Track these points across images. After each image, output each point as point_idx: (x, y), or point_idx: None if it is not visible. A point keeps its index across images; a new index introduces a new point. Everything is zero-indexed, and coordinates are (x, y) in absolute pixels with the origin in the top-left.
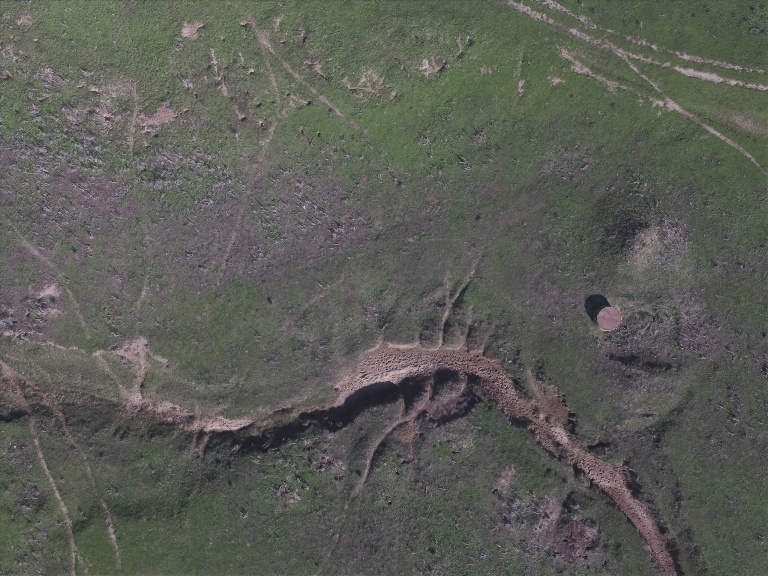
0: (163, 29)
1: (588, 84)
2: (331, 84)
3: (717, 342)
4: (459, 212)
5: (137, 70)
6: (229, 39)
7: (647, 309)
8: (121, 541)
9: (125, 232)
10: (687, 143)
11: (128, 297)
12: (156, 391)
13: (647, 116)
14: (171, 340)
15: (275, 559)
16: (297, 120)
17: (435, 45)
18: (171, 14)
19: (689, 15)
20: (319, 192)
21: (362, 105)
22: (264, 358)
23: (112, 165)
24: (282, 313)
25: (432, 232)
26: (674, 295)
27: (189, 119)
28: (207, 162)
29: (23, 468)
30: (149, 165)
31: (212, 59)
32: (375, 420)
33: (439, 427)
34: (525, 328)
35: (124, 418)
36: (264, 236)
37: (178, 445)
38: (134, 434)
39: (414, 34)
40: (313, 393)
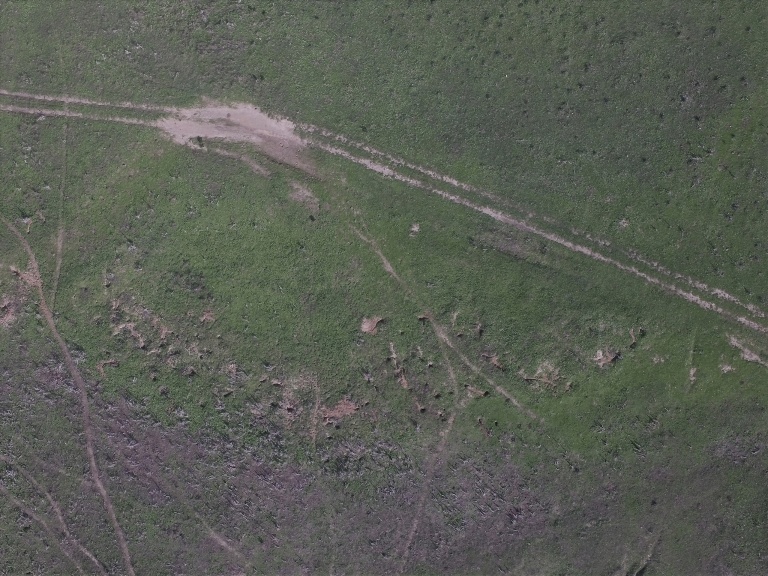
0: (343, 325)
1: (758, 371)
2: (508, 376)
3: None
4: (635, 497)
5: (318, 363)
6: (408, 333)
7: None
8: None
9: (310, 522)
10: None
11: None
12: None
13: None
14: None
15: None
16: (475, 410)
17: (609, 337)
18: (351, 310)
19: None
20: (497, 479)
21: (539, 396)
22: None
23: (296, 457)
24: None
25: (609, 517)
26: None
27: (370, 411)
28: (388, 452)
29: None
30: (332, 456)
31: (392, 353)
32: None
33: None
34: None
35: None
36: (445, 523)
37: None
38: None
39: (588, 326)
40: None
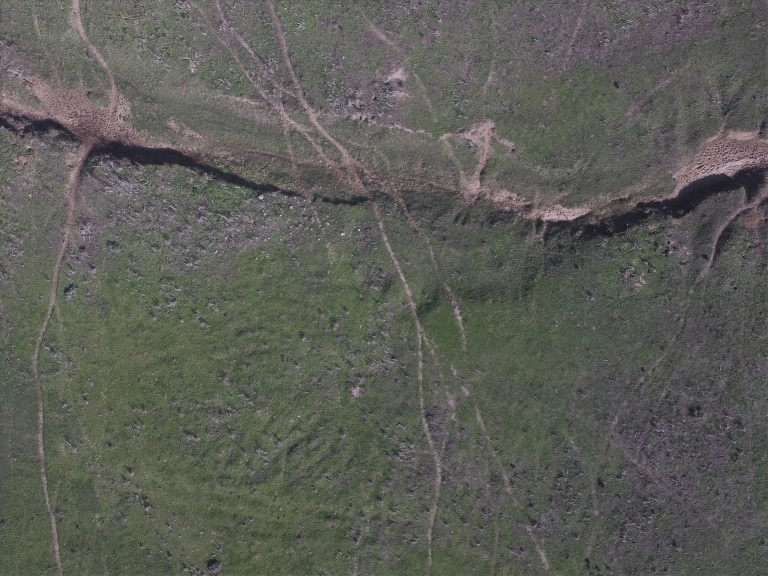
0: None
1: None
2: None
3: None
4: None
5: None
6: None
7: None
8: (467, 322)
9: (472, 17)
10: None
11: (475, 81)
12: (496, 178)
13: None
14: (518, 124)
15: (620, 342)
16: None
17: None
18: None
19: None
20: None
21: None
22: (609, 143)
23: None
24: (628, 98)
25: None
26: None
27: None
28: None
29: (368, 251)
30: None
31: None
32: (718, 206)
33: None
34: None
35: (462, 206)
36: (609, 22)
37: (519, 231)
38: (474, 220)
39: None
40: (653, 182)
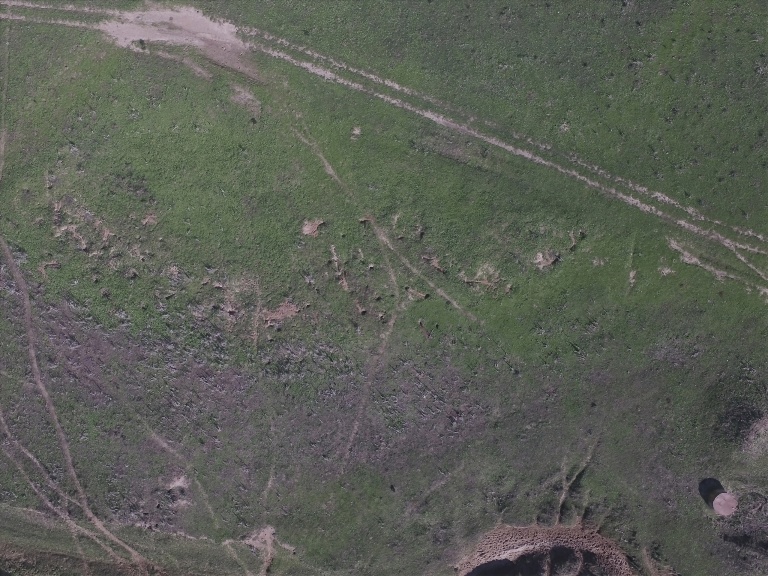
0: (285, 227)
1: (697, 274)
2: (449, 278)
3: None
4: (575, 399)
5: (259, 266)
6: (349, 236)
7: (759, 491)
8: None
9: (251, 424)
10: None
11: (255, 487)
12: (282, 575)
13: (755, 304)
14: (298, 529)
15: None
16: (416, 313)
17: (549, 239)
18: (292, 212)
19: None
20: (438, 382)
21: (479, 298)
22: (388, 544)
23: (237, 359)
24: (405, 500)
25: (549, 419)
26: None
27: (311, 314)
28: (329, 355)
29: None
30: (273, 358)
31: (333, 255)
32: None
33: None
34: (641, 511)
35: None
36: (385, 425)
37: None
38: None
39: (528, 229)
40: (434, 574)
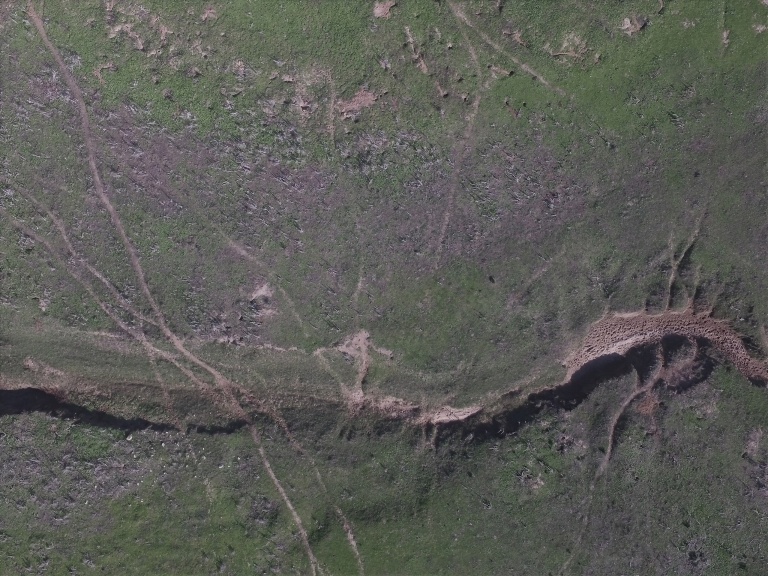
0: (355, 11)
1: None
2: (533, 52)
3: None
4: (676, 171)
5: (330, 56)
6: (423, 15)
7: None
8: (362, 547)
9: (335, 223)
10: None
11: (344, 290)
12: (379, 386)
13: None
14: (394, 330)
15: (524, 549)
16: (501, 92)
17: (635, 3)
18: None
19: None
20: (530, 163)
21: (567, 70)
22: (491, 340)
23: (314, 155)
24: (505, 291)
25: (651, 193)
26: None
27: (390, 101)
28: (412, 143)
29: (250, 480)
30: (352, 152)
31: (408, 37)
32: (611, 393)
33: (680, 394)
34: (757, 283)
35: (347, 418)
36: (478, 214)
37: (408, 440)
38: (360, 433)
39: None
40: (542, 372)
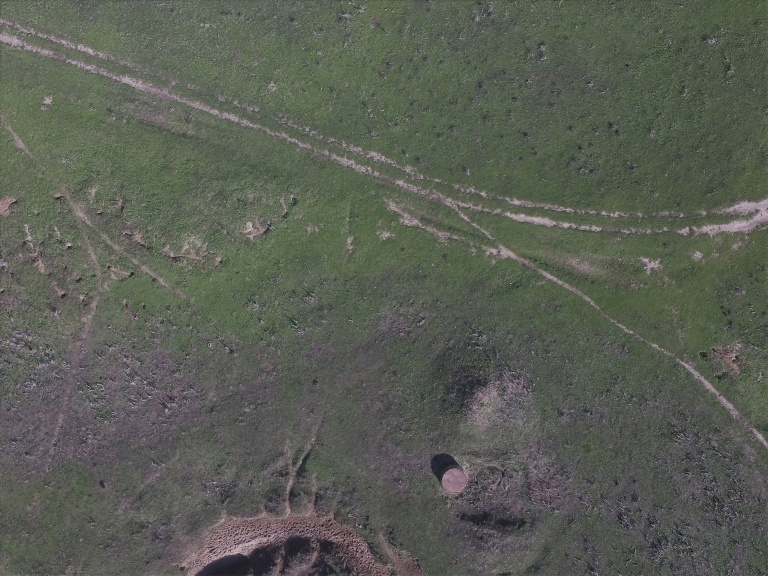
0: None
1: (419, 236)
2: (152, 254)
3: (570, 493)
4: (295, 377)
5: None
6: (43, 214)
7: (495, 465)
8: None
9: None
10: (524, 290)
11: None
12: None
13: (481, 265)
14: None
15: None
16: (120, 293)
17: (258, 207)
18: None
19: (517, 159)
20: (148, 366)
21: (186, 274)
22: (100, 545)
23: None
24: (116, 496)
25: (268, 400)
26: (520, 450)
27: (6, 300)
28: (28, 343)
29: None
30: None
31: (26, 236)
32: None
33: None
34: (371, 493)
35: None
36: (93, 416)
37: None
38: None
39: (236, 197)
40: (157, 575)
